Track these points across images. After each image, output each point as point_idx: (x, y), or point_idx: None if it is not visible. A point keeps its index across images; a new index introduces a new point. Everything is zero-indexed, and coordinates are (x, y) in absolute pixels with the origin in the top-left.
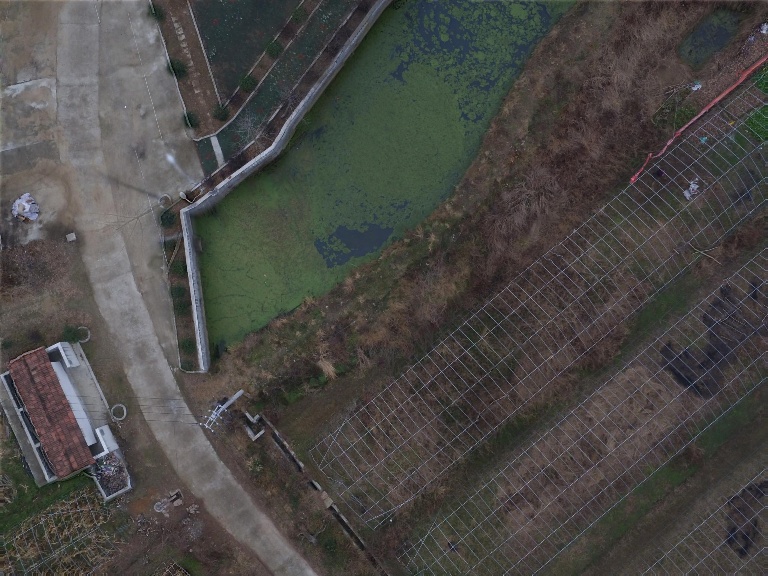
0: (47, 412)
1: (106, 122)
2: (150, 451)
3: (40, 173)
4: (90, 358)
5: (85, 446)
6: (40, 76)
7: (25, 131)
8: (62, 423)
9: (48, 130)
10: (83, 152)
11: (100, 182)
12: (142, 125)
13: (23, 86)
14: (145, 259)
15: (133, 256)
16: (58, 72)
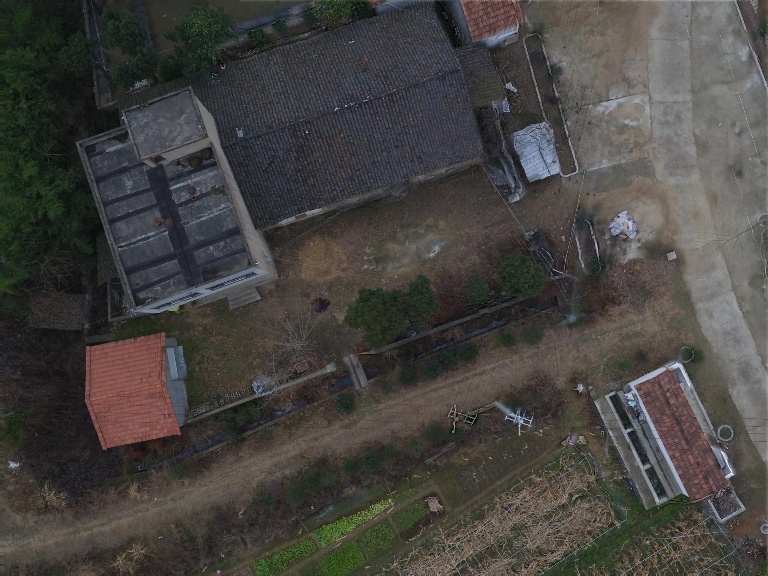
0: (685, 434)
1: (701, 139)
2: (756, 472)
3: (637, 191)
4: (693, 378)
5: (719, 468)
6: (633, 92)
7: (620, 148)
8: (697, 445)
9: (643, 147)
10: (679, 170)
11: (698, 200)
12: (738, 143)
13: (615, 102)
14: (746, 278)
15: (734, 275)
16: (651, 89)
